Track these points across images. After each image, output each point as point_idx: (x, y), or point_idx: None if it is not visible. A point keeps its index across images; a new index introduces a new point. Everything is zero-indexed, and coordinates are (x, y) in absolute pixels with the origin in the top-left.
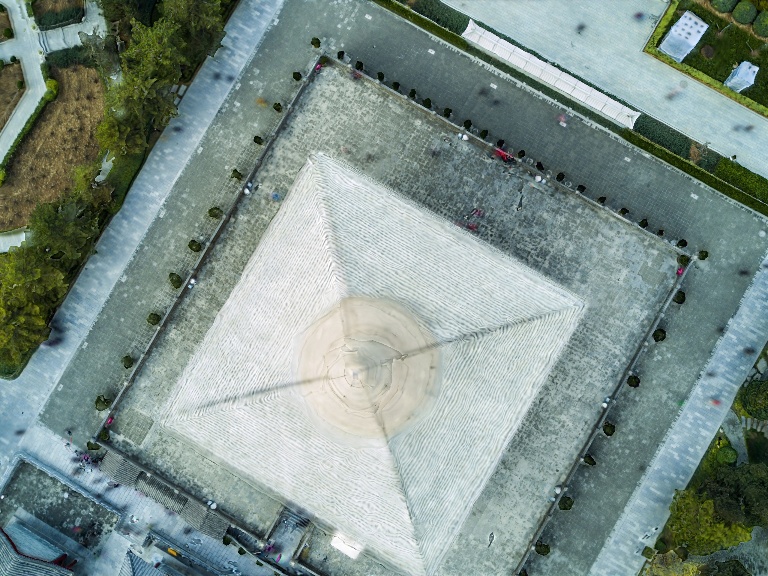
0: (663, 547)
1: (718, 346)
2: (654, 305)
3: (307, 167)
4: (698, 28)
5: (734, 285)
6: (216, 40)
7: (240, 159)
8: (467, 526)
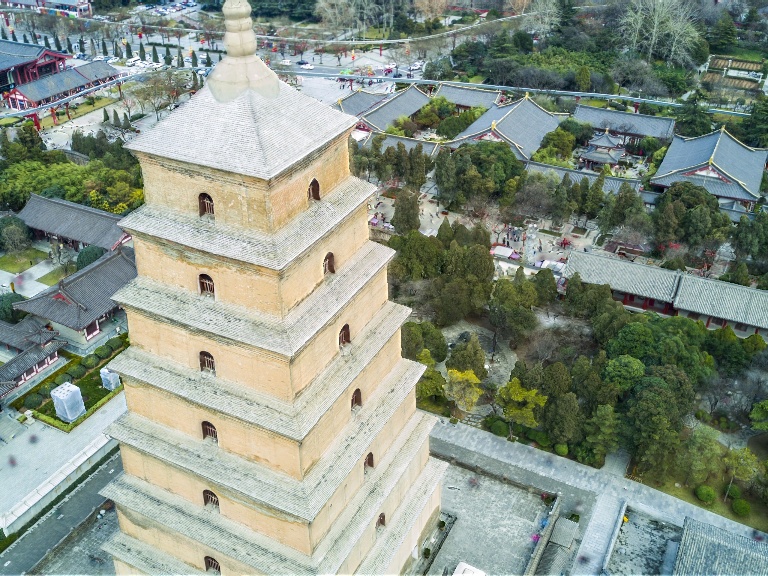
0: (448, 412)
1: None
2: None
3: (129, 144)
4: (66, 386)
5: None
6: None
7: None
8: (445, 504)
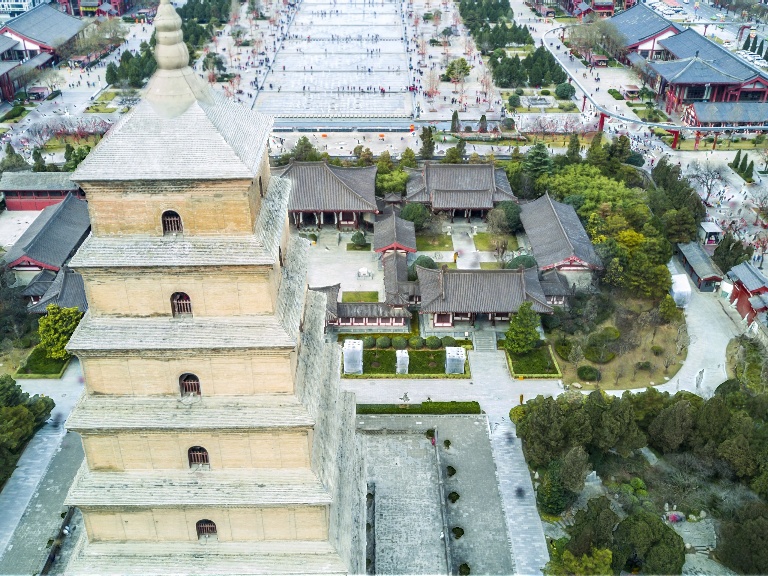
0: None
1: (501, 490)
2: (431, 467)
3: None
4: (357, 343)
5: (482, 454)
6: (11, 461)
7: (51, 538)
8: None
